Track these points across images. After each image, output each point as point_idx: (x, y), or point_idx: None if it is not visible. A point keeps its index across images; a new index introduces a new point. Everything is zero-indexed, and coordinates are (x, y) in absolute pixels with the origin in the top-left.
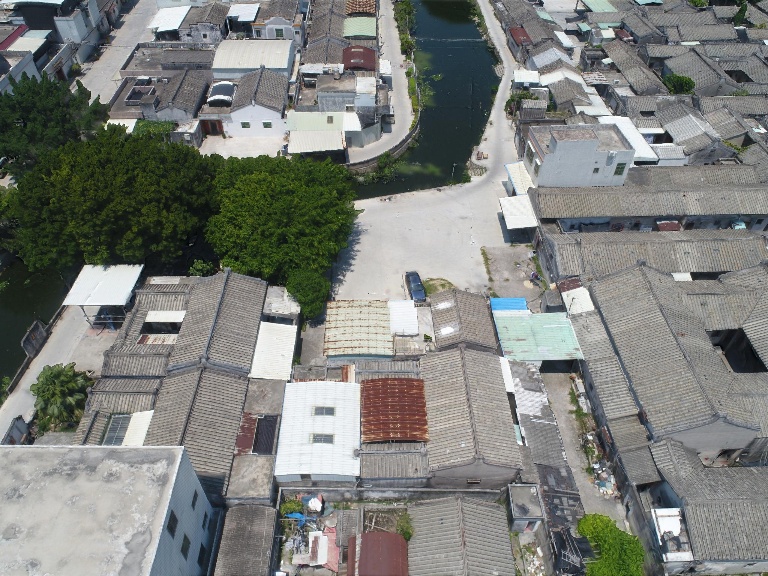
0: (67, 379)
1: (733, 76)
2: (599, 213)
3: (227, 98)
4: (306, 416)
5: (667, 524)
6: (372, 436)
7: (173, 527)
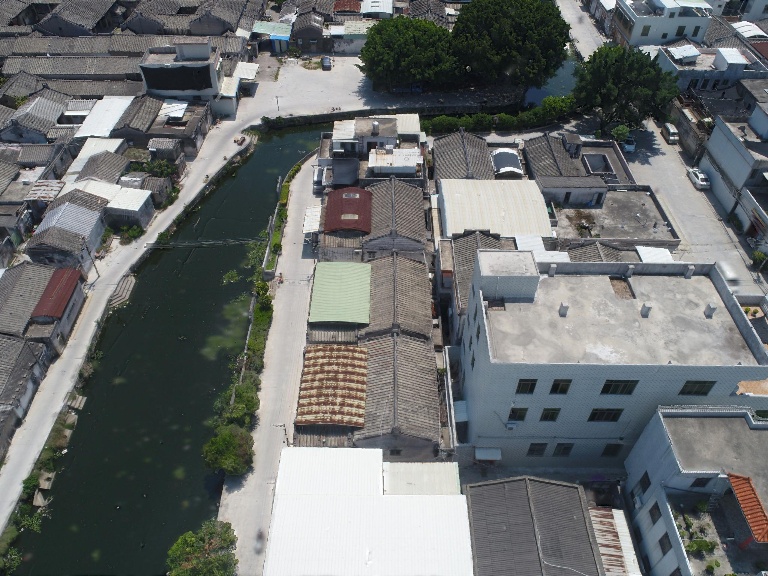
0: None
1: None
2: None
3: (496, 151)
4: (383, 6)
5: None
6: (356, 1)
7: None
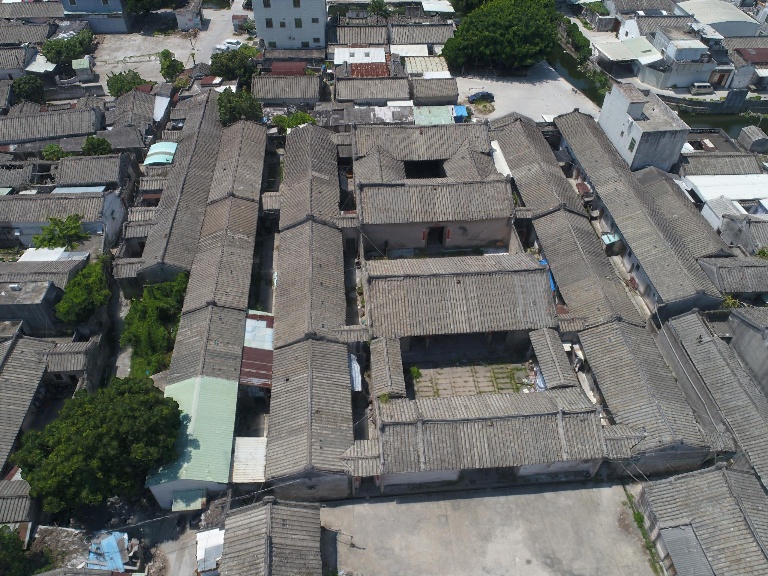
0: (377, 5)
1: None
2: (572, 143)
3: None
4: (364, 51)
5: None
6: None
7: (296, 4)
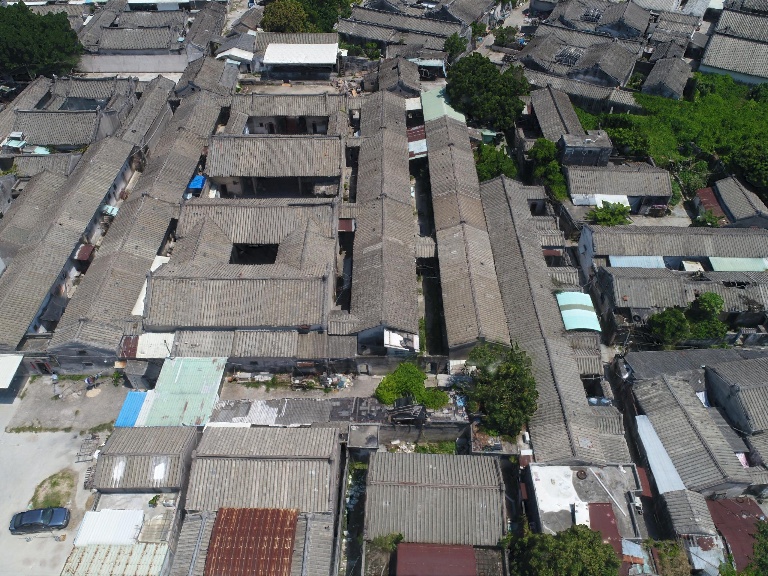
0: None
1: None
2: (41, 295)
3: None
4: None
5: (395, 341)
6: (285, 571)
7: None
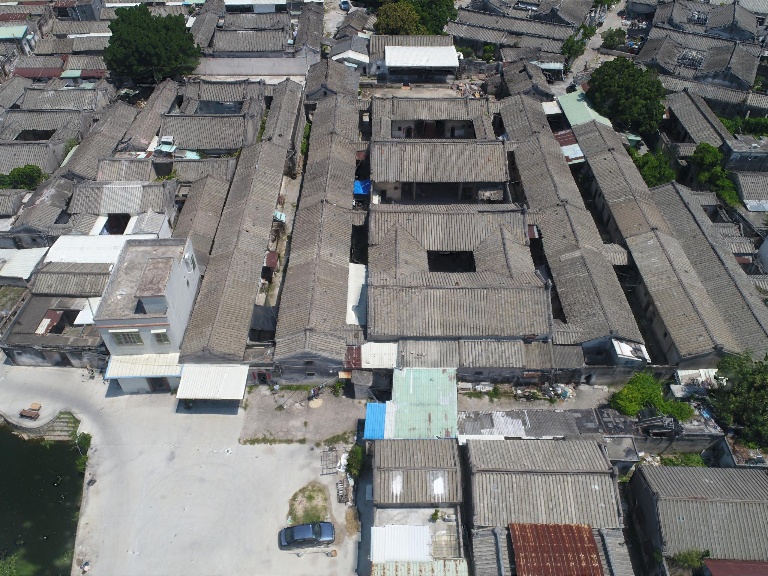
0: None
1: (19, 140)
2: (250, 303)
3: None
4: None
5: (626, 351)
6: None
7: None
